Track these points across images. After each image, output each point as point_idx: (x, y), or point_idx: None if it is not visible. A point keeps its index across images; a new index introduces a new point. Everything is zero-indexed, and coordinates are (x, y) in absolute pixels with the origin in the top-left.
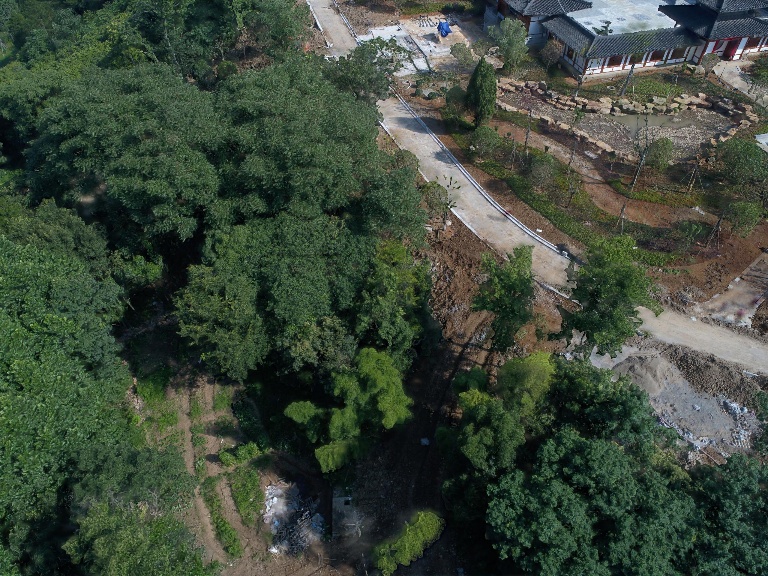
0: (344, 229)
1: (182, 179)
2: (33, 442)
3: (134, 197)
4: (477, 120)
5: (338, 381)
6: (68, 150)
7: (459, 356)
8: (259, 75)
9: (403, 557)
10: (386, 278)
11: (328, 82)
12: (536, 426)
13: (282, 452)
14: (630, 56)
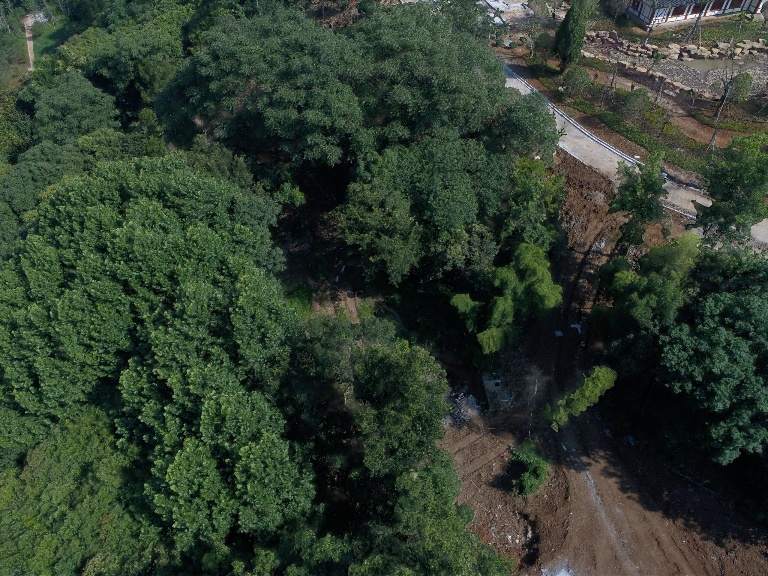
0: (482, 150)
1: (337, 108)
2: (269, 315)
3: (288, 128)
4: (563, 64)
5: (500, 272)
6: (218, 90)
7: (582, 262)
8: (390, 17)
9: (580, 404)
10: (533, 186)
11: (452, 23)
12: (684, 297)
13: (428, 349)
14: (693, 6)
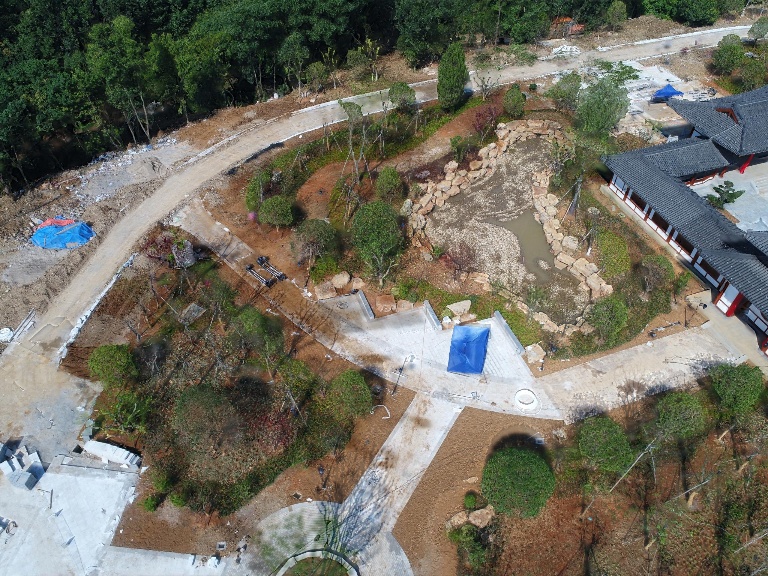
0: None
1: None
2: None
3: None
4: None
5: None
6: None
7: None
8: None
9: None
10: None
11: None
12: None
13: None
14: None
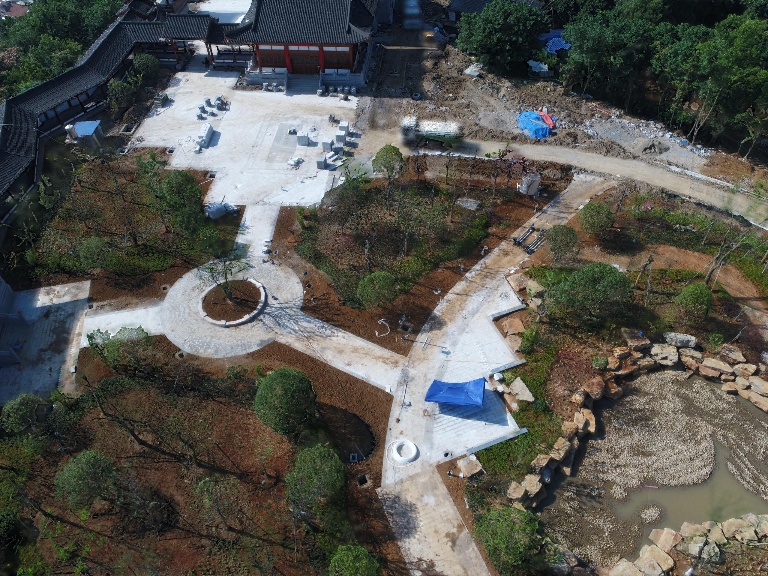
0: None
1: None
2: None
3: None
4: None
5: None
6: None
7: None
8: None
9: None
10: None
11: None
12: None
13: None
14: None
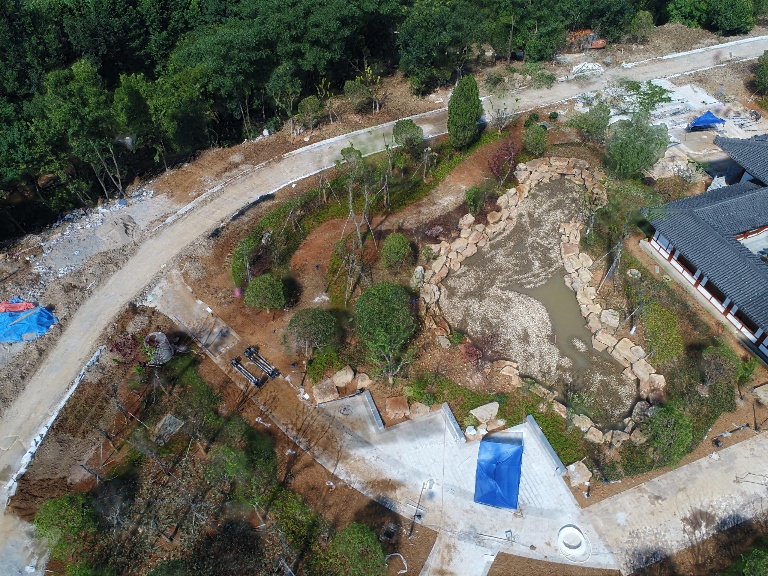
0: None
1: None
2: None
3: None
4: None
5: None
6: None
7: None
8: None
9: None
10: None
11: None
12: None
13: None
14: None
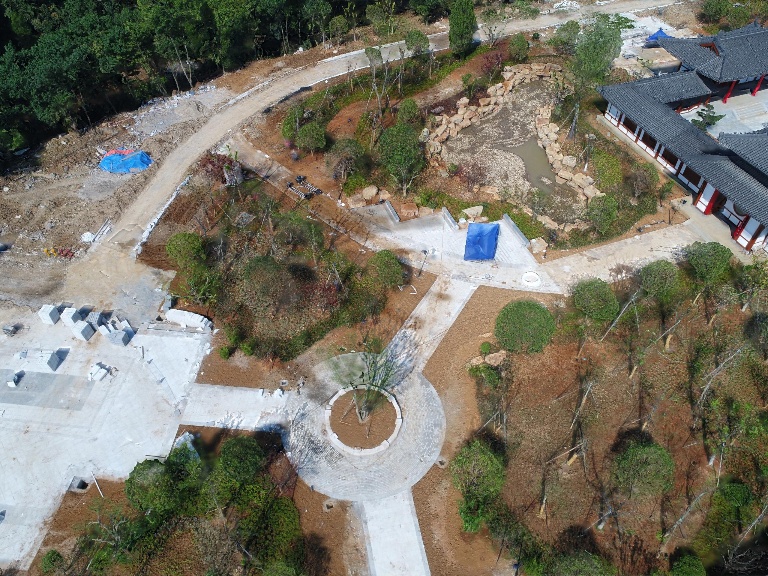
0: None
1: None
2: None
3: None
4: None
5: None
6: None
7: None
8: None
9: None
10: None
11: None
12: None
13: None
14: None
